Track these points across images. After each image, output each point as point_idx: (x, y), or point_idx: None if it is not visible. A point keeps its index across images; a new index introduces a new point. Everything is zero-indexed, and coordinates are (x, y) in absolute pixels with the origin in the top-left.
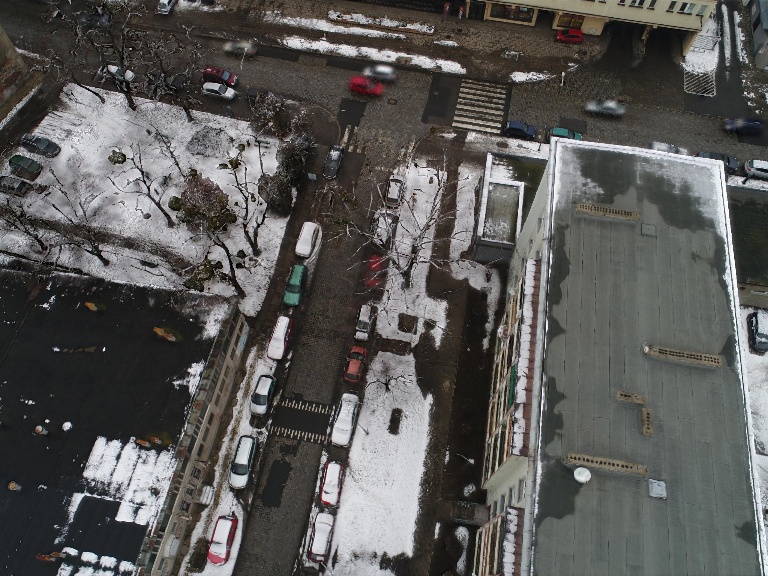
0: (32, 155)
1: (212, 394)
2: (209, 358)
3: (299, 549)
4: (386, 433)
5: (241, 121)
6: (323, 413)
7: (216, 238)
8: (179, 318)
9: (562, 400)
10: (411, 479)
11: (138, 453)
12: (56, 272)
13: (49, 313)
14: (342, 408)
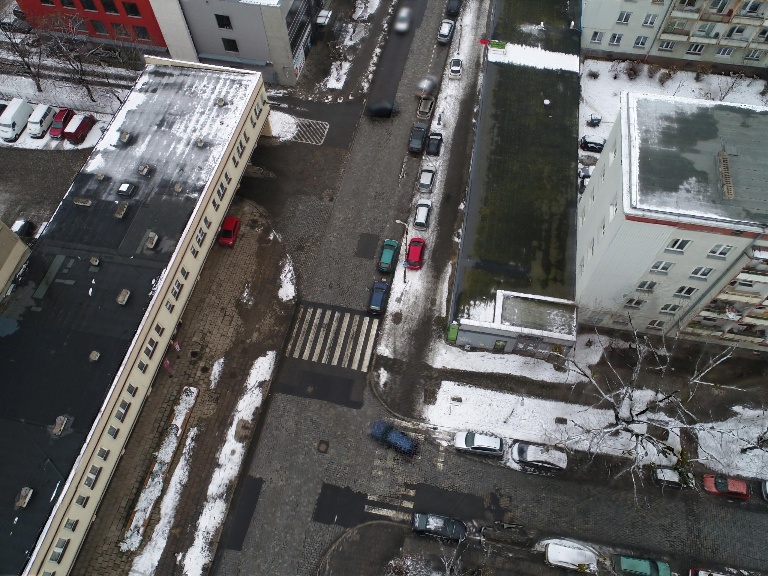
0: None
1: None
2: None
3: None
4: None
5: None
6: None
7: None
8: None
9: None
10: None
11: None
12: None
13: None
14: None
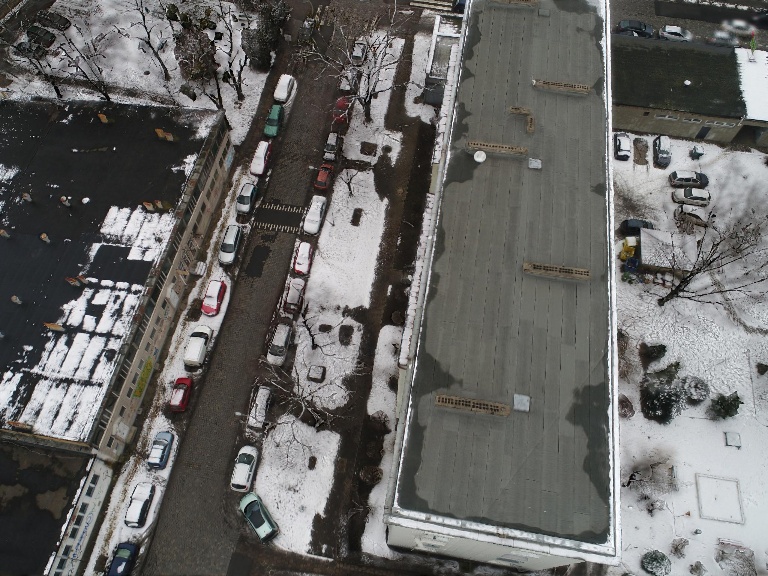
0: (46, 29)
1: (204, 185)
2: (201, 151)
3: (277, 305)
4: (349, 225)
5: (227, 2)
6: (297, 212)
7: (206, 88)
8: (176, 126)
9: (469, 116)
10: (369, 256)
11: (144, 215)
12: (72, 98)
13: (68, 126)
14: (312, 204)
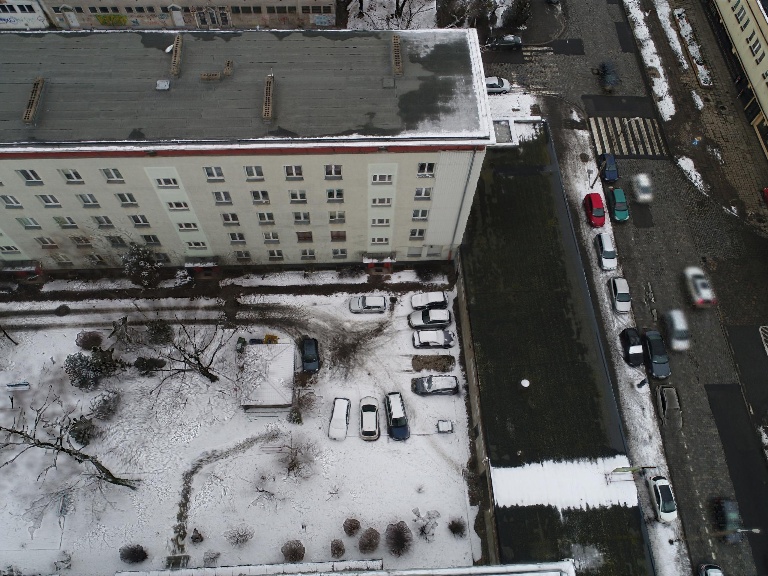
0: None
1: None
2: None
3: None
4: None
5: None
6: None
7: None
8: None
9: (225, 40)
10: None
11: None
12: None
13: None
14: None
